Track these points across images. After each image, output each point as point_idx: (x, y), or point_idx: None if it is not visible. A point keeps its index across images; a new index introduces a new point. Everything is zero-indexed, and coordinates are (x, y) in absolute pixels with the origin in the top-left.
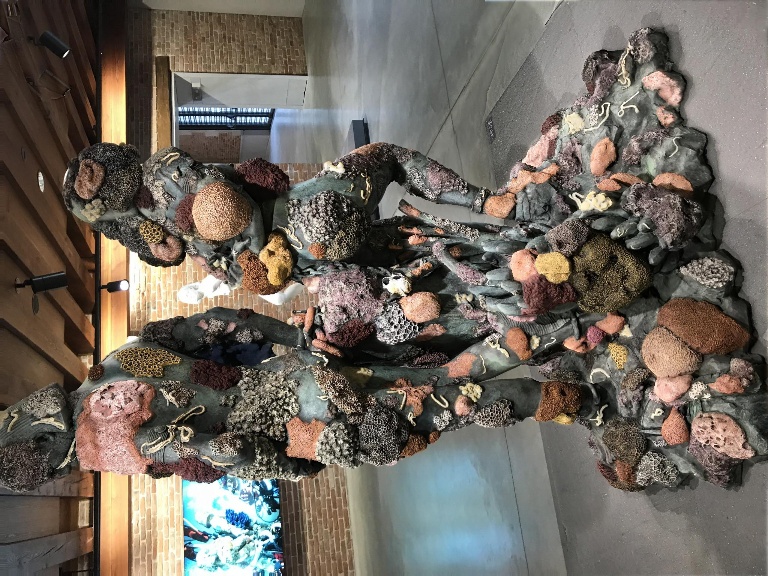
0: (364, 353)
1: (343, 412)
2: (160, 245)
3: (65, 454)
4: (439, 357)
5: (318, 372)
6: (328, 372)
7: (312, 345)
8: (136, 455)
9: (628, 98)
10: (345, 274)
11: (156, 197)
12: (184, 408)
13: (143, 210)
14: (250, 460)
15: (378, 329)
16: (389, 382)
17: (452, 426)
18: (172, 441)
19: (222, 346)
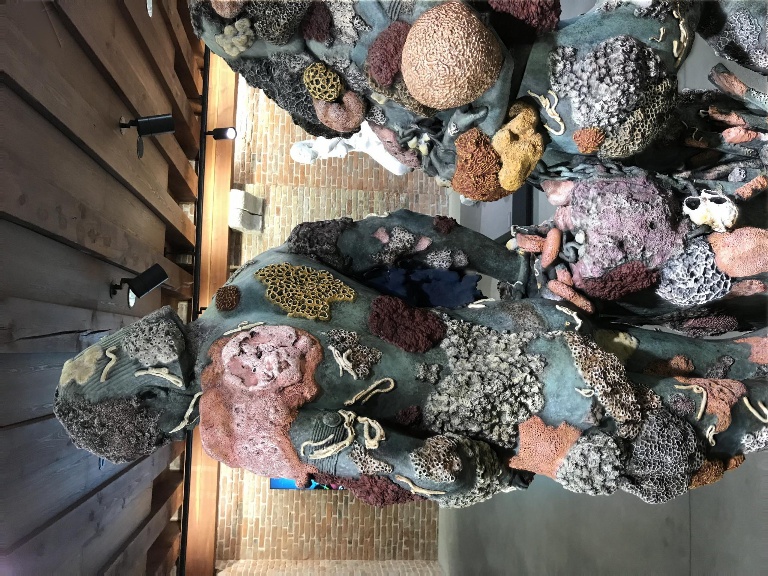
0: (616, 305)
1: (612, 417)
2: (333, 105)
3: (181, 416)
4: (726, 322)
5: (579, 348)
6: (593, 349)
7: (546, 288)
8: (293, 457)
9: None
10: (625, 184)
11: (339, 23)
12: (364, 380)
13: (313, 44)
14: (468, 485)
15: (665, 279)
16: (661, 360)
17: (762, 447)
18: (351, 444)
19: (401, 266)
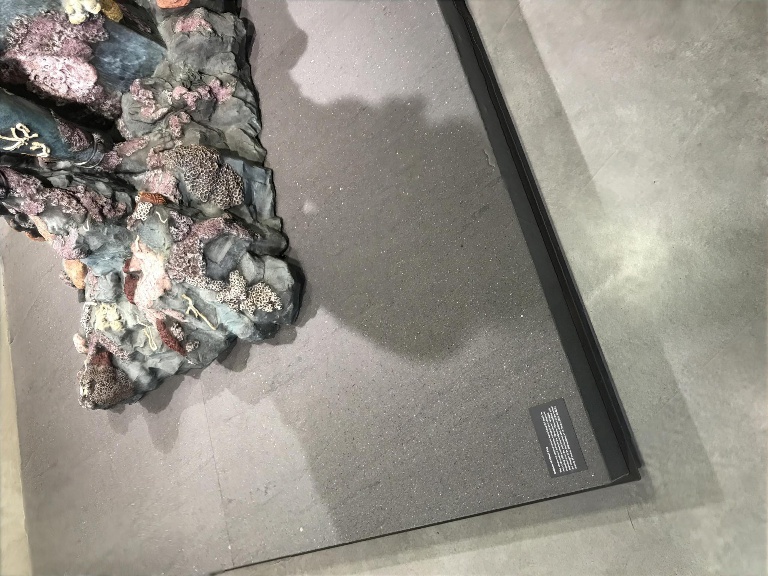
0: None
1: None
2: None
3: None
4: None
5: None
6: None
7: None
8: None
9: None
10: None
11: None
12: None
13: None
14: None
15: None
16: None
17: None
18: None
19: None
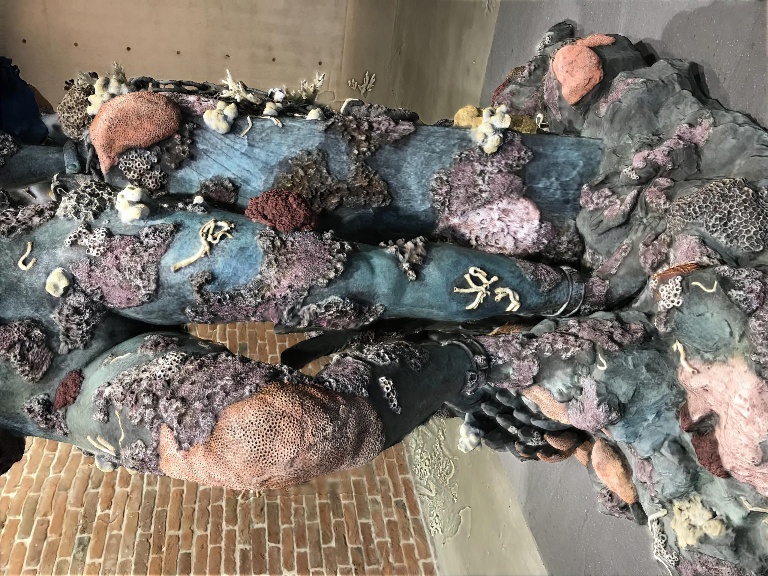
0: None
1: None
2: None
3: None
4: None
5: None
6: None
7: None
8: None
9: (675, 574)
10: None
11: None
12: None
13: None
14: None
15: None
16: None
17: None
18: None
19: None
